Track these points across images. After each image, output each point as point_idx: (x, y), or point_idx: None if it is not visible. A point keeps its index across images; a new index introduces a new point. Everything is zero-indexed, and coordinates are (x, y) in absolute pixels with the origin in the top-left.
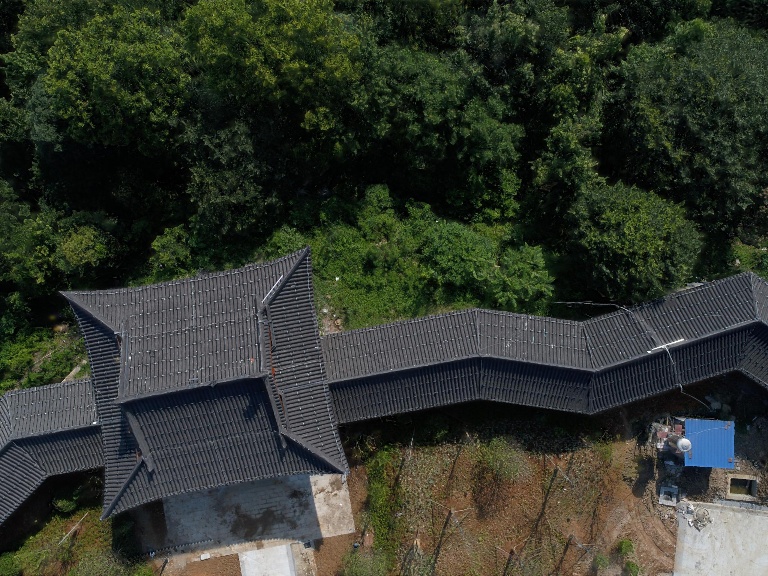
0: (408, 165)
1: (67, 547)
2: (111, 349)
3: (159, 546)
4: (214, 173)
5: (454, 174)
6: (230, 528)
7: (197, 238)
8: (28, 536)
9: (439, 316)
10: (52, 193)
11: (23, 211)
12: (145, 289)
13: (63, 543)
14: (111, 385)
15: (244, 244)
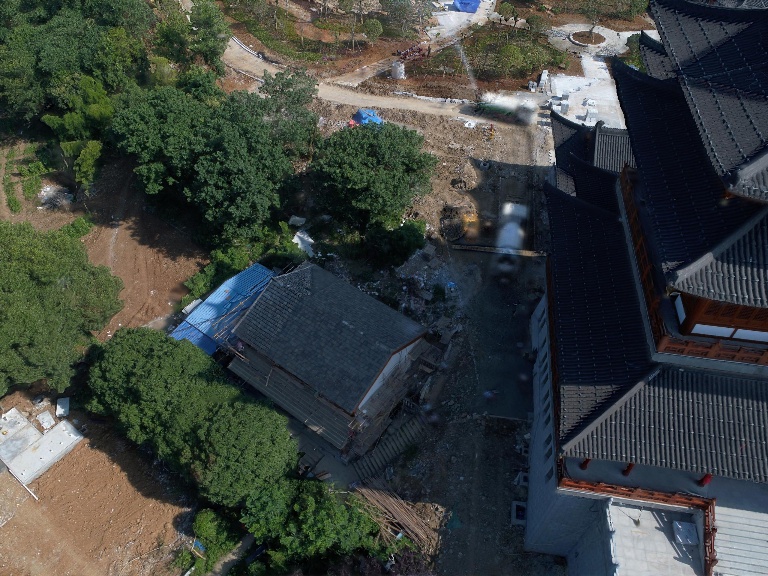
0: None
1: None
2: None
3: None
4: None
5: None
6: None
7: None
8: None
9: None
10: None
11: None
12: None
13: None
14: None
15: None
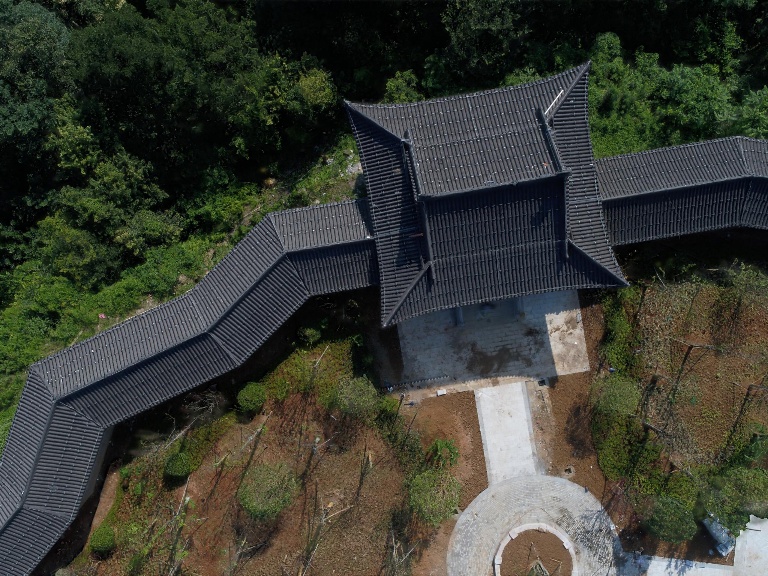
0: (644, 10)
1: (308, 379)
2: (391, 161)
3: (396, 381)
4: None
5: (679, 26)
6: (466, 365)
7: (433, 79)
8: (268, 368)
9: (701, 143)
10: (277, 38)
11: (251, 53)
12: (421, 104)
13: (305, 375)
14: (389, 197)
15: (477, 87)
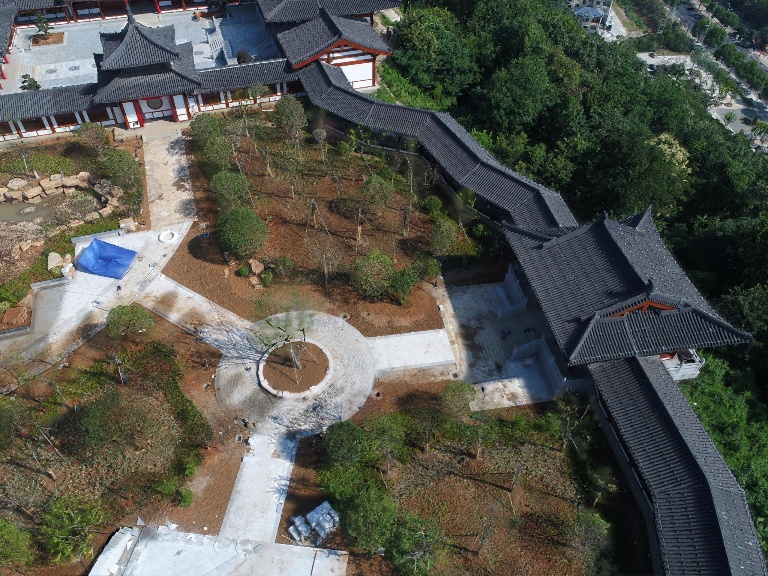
0: None
1: None
2: None
3: (447, 282)
4: (764, 297)
5: None
6: (465, 324)
7: None
8: (450, 216)
9: None
10: (677, 239)
11: None
12: None
13: None
14: None
15: None
